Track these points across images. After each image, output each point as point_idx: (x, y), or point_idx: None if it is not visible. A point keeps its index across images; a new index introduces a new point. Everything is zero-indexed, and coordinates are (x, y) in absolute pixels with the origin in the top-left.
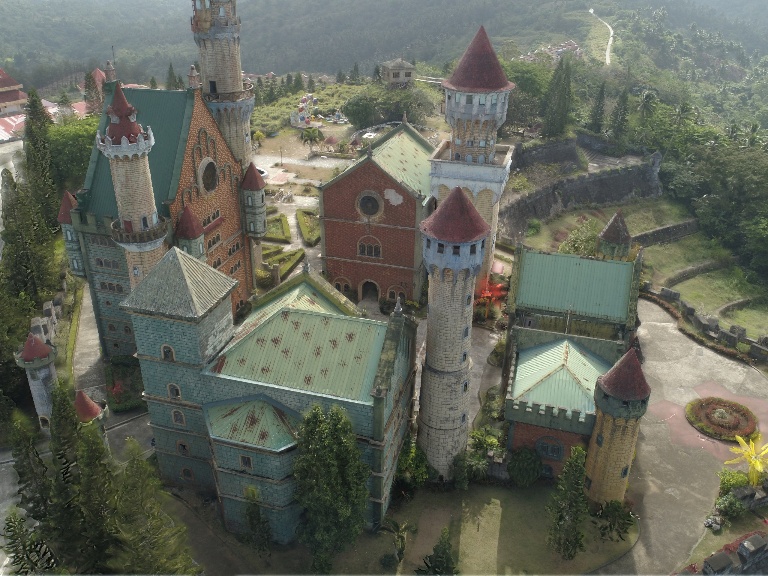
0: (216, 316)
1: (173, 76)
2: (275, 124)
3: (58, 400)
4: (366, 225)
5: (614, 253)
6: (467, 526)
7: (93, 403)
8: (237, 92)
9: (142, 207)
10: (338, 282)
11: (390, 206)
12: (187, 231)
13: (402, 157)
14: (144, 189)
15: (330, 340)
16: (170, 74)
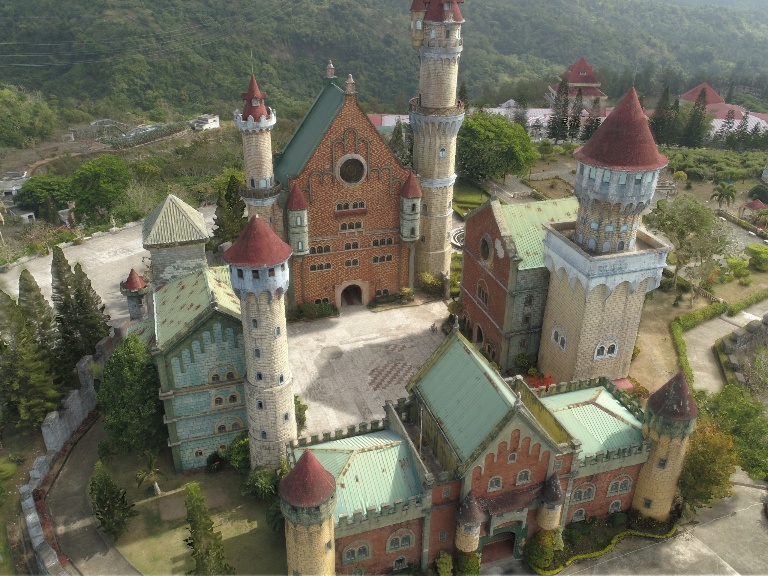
0: (180, 255)
1: (666, 98)
2: (733, 171)
3: (56, 252)
4: (483, 268)
5: (650, 422)
6: (216, 518)
7: (138, 281)
8: (432, 108)
9: (252, 171)
10: (465, 315)
11: (497, 257)
12: (289, 203)
13: (562, 217)
14: (255, 158)
15: (192, 303)
16: (664, 95)
